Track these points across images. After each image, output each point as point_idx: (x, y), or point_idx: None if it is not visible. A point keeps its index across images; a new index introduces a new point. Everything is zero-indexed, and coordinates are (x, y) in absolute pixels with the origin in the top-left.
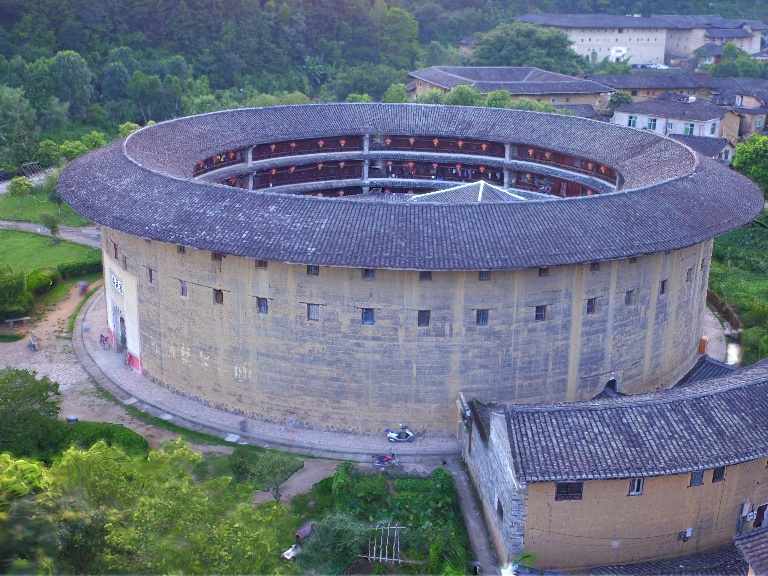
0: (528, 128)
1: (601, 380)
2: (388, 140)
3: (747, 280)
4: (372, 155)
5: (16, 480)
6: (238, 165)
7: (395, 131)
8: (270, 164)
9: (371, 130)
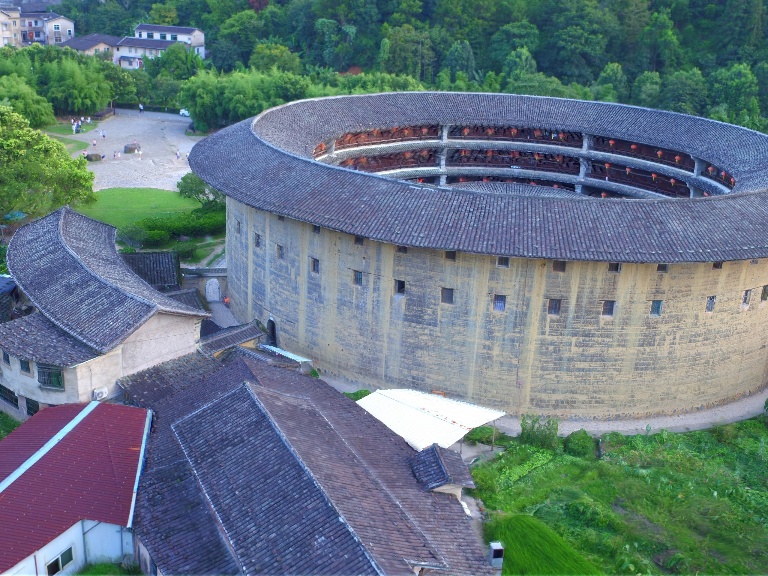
0: (766, 183)
1: (265, 314)
2: (710, 167)
3: (730, 466)
4: (697, 180)
5: None
6: (574, 148)
7: (712, 158)
8: (603, 157)
9: (697, 151)
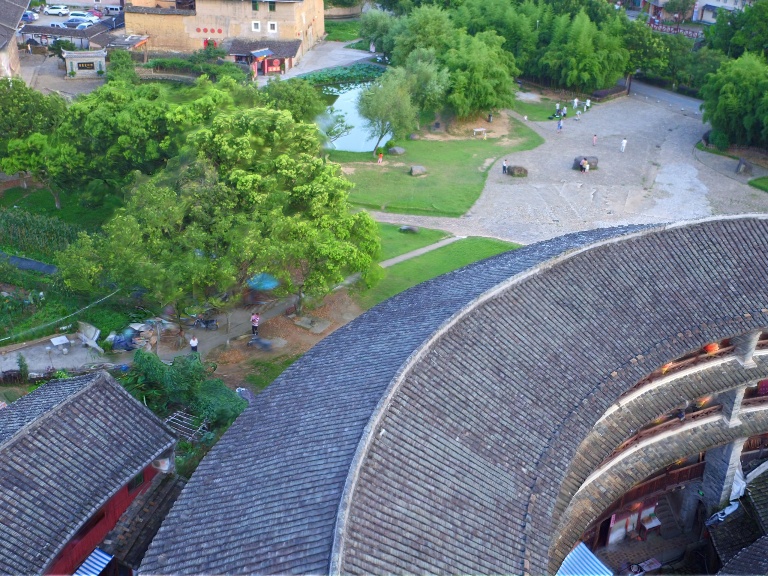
0: None
1: None
2: None
3: None
4: None
5: (238, 172)
6: None
7: None
8: None
9: None
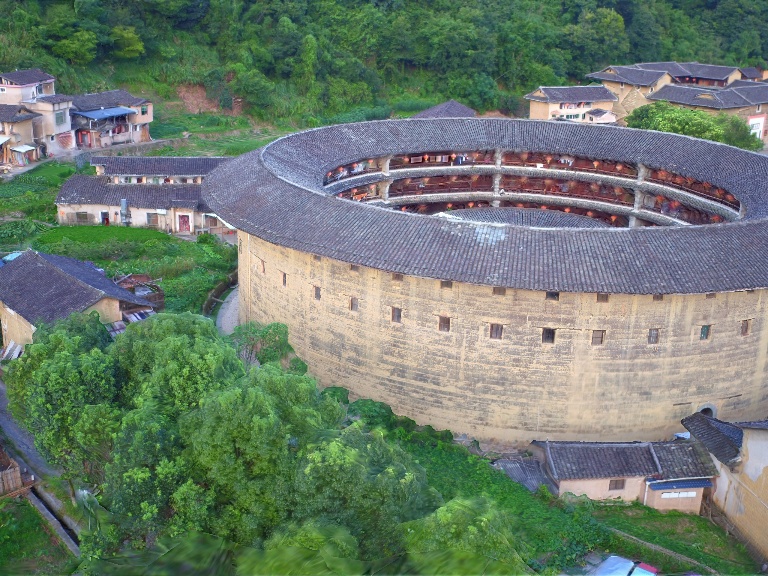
0: None
1: None
2: None
3: None
4: None
5: None
6: None
7: None
8: None
9: None
